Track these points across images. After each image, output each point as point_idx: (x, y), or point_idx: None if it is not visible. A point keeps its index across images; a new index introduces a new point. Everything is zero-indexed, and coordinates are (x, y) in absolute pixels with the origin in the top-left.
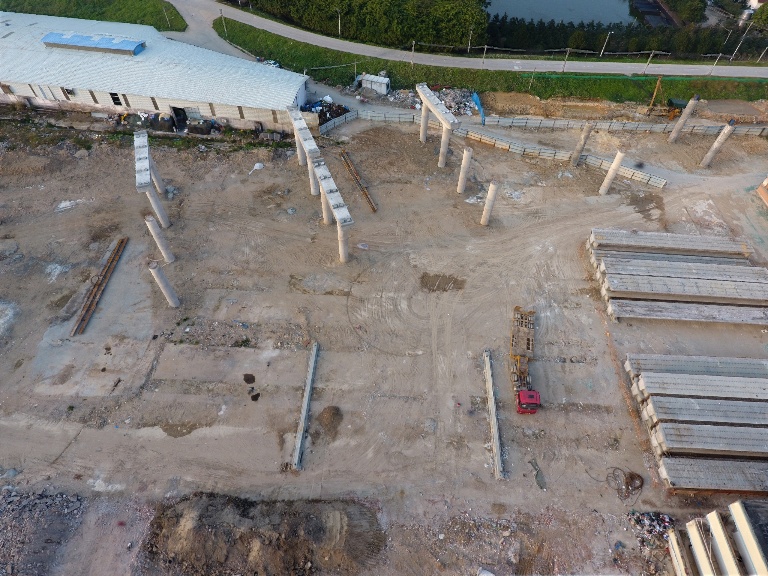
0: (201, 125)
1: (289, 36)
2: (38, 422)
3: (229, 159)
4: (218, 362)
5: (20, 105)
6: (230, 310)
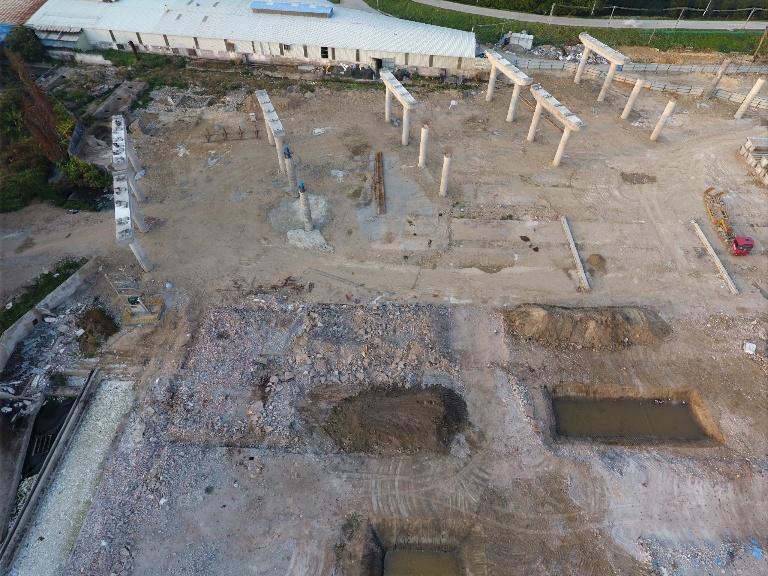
0: (397, 72)
1: (433, 5)
2: (387, 266)
3: (429, 97)
4: (496, 229)
5: (239, 60)
6: (487, 197)
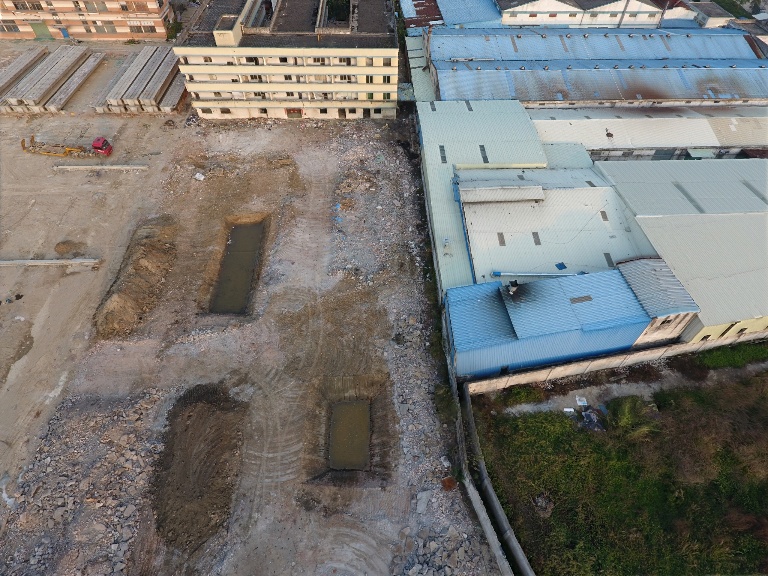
0: None
1: None
2: None
3: None
4: None
5: None
6: None
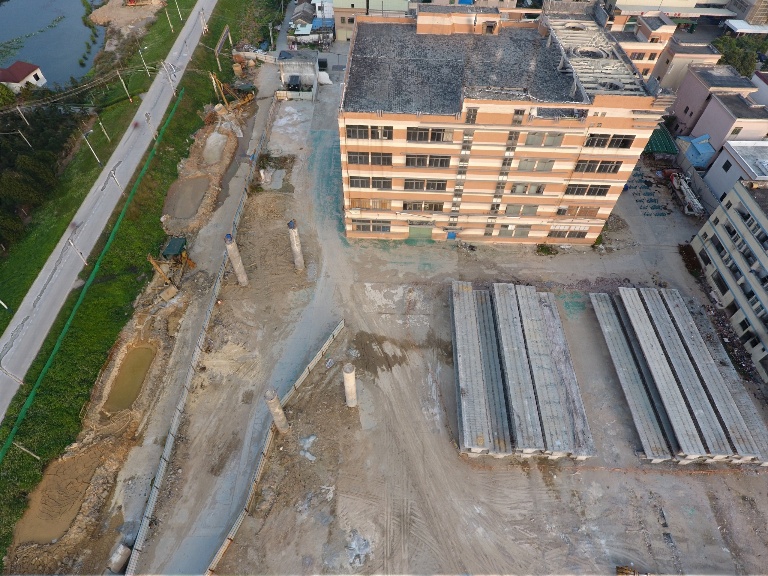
0: None
1: None
2: None
3: None
4: None
5: None
6: None
